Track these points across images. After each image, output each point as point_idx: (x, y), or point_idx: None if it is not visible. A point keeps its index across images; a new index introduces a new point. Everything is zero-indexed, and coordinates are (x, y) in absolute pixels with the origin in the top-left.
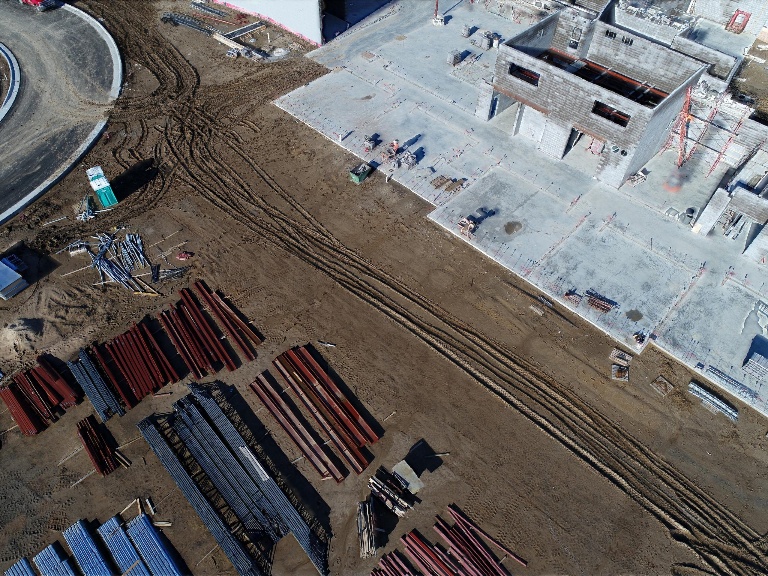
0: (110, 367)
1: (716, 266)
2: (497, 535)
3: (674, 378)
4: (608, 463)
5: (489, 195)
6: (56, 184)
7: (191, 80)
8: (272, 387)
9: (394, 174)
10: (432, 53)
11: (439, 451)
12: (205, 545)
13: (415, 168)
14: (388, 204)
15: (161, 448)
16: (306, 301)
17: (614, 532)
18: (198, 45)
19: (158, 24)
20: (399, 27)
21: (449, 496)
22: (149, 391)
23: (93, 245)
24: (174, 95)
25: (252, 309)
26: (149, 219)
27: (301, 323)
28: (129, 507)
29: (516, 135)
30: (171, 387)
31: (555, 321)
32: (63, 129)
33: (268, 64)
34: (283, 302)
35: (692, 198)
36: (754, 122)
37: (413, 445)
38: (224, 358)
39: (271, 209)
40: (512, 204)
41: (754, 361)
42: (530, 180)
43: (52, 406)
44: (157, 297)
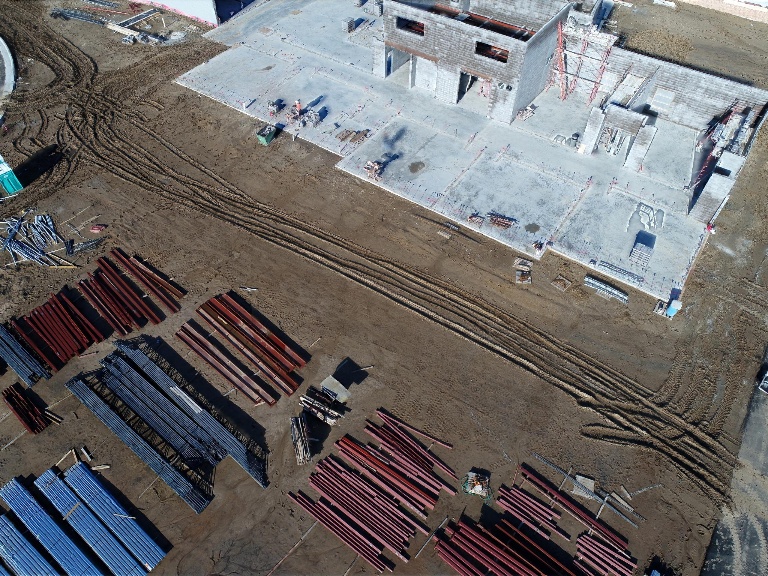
0: (31, 337)
1: (601, 179)
2: (423, 427)
3: (571, 275)
4: (518, 353)
5: (392, 142)
6: None
7: (88, 69)
8: (198, 332)
9: (300, 133)
10: (327, 23)
11: (364, 365)
12: (145, 479)
13: (320, 125)
14: (297, 160)
15: (91, 399)
16: (224, 254)
17: (528, 409)
18: (92, 36)
19: (48, 20)
20: (293, 3)
21: (377, 402)
22: (74, 353)
23: (1, 230)
24: (72, 84)
25: (171, 267)
26: (58, 199)
27: (221, 274)
28: (64, 458)
29: (413, 88)
30: (96, 347)
31: (462, 242)
32: None
33: (166, 47)
34: (202, 258)
35: (576, 125)
36: (620, 49)
37: (339, 364)
38: (147, 313)
39: (182, 177)
40: (414, 147)
41: (637, 250)
42: (429, 125)
43: None
44: (73, 269)
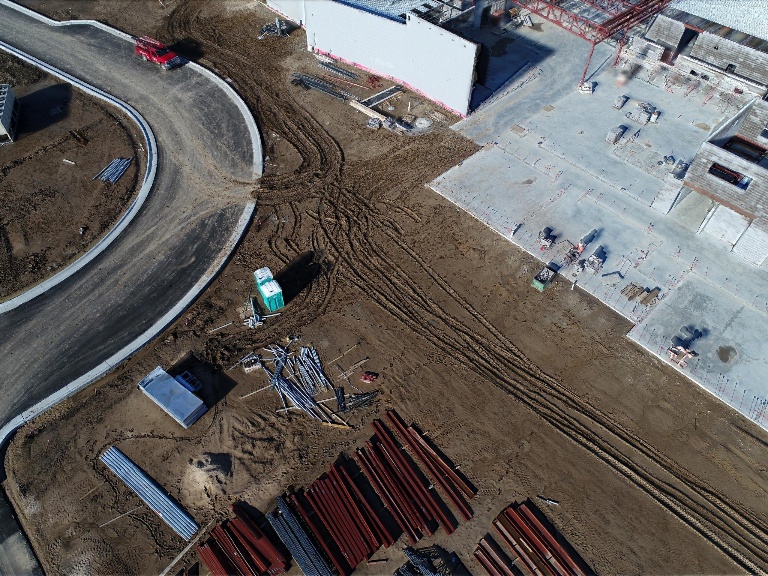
0: (313, 521)
1: None
2: None
3: None
4: None
5: (690, 310)
6: (214, 280)
7: (334, 155)
8: (500, 558)
9: (579, 280)
10: (586, 128)
11: None
12: None
13: (600, 273)
14: (579, 318)
15: None
16: (513, 442)
17: None
18: (335, 113)
19: (289, 87)
20: (543, 95)
21: None
22: (363, 557)
23: (267, 359)
24: (320, 173)
25: (455, 450)
26: (321, 328)
27: (513, 471)
28: None
29: (702, 233)
30: (385, 552)
31: None
32: (211, 212)
33: (413, 137)
34: (488, 442)
35: None
36: None
37: None
38: (438, 516)
39: (451, 319)
40: (718, 323)
41: None
42: (731, 292)
43: (260, 573)
44: (348, 430)
